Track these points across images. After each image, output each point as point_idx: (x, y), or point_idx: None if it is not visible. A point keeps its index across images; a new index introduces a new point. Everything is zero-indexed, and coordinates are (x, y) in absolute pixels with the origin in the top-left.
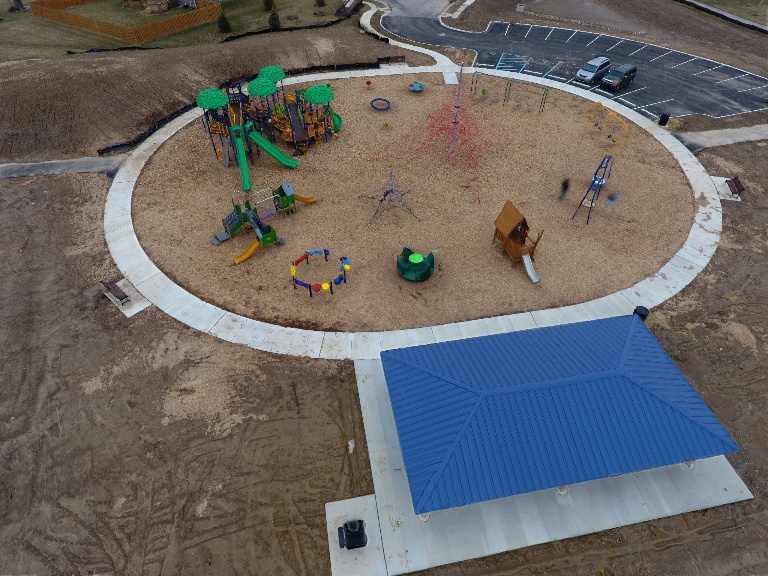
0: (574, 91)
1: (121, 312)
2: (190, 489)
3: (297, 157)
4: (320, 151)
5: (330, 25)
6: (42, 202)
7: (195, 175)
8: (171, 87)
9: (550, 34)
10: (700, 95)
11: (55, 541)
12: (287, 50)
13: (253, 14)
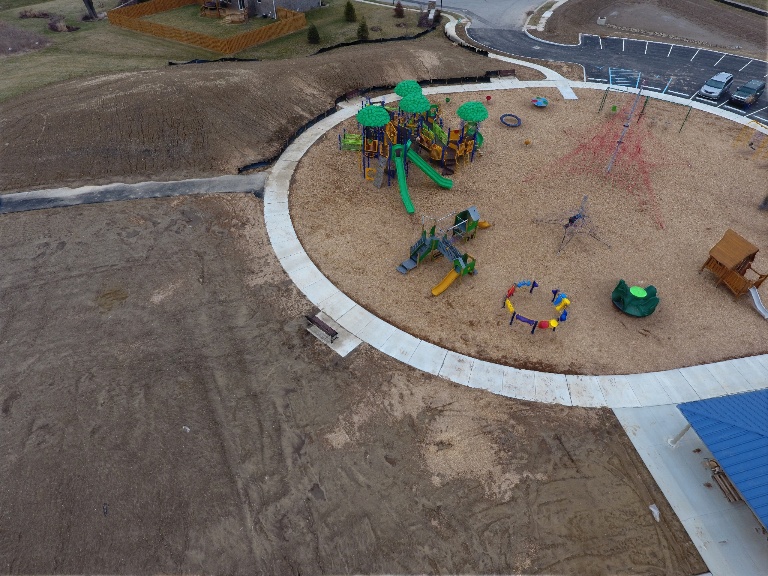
0: (703, 108)
1: (333, 350)
2: (495, 565)
3: (447, 177)
4: (468, 170)
5: (418, 37)
6: (199, 225)
7: (348, 196)
8: (290, 101)
9: (647, 48)
10: None
11: None
12: (394, 63)
13: (335, 25)
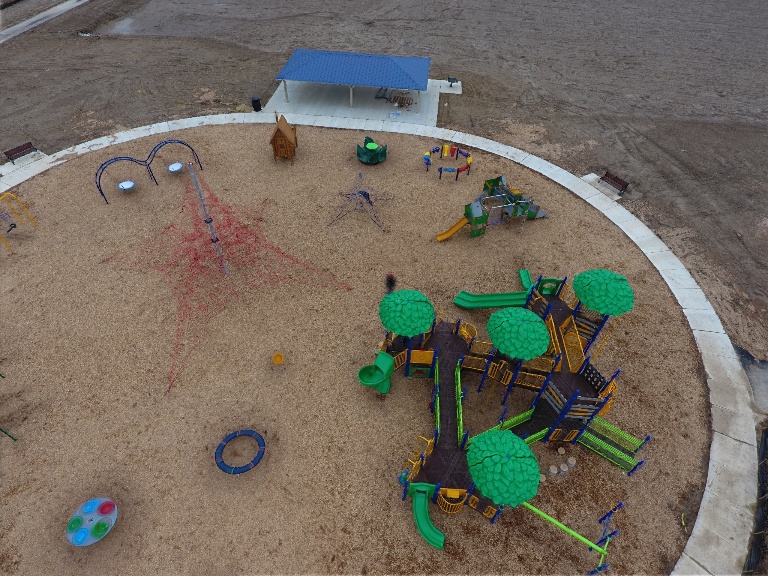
0: None
1: None
2: None
3: None
4: None
5: None
6: None
7: None
8: None
9: None
10: None
11: (575, 108)
12: None
13: None
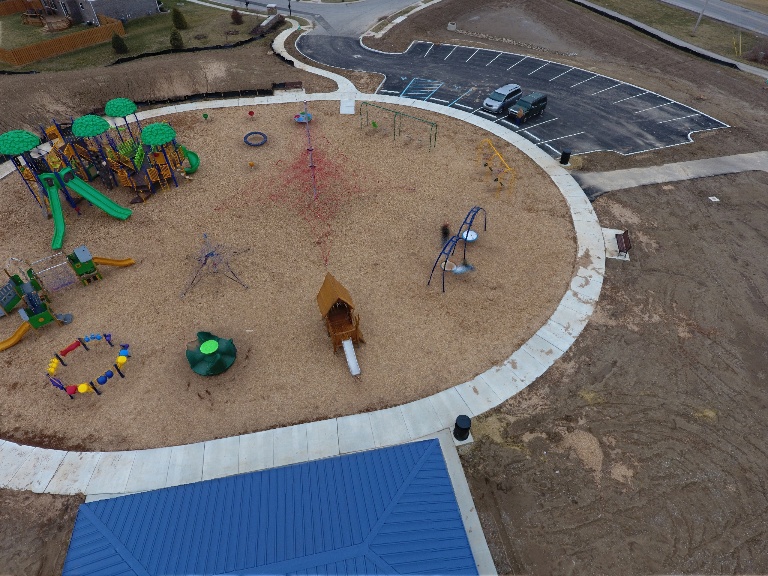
0: (478, 122)
1: None
2: None
3: (136, 205)
4: (166, 197)
5: (239, 45)
6: None
7: (5, 229)
8: (21, 119)
9: (472, 56)
10: (614, 127)
11: None
12: (172, 75)
13: (160, 32)
